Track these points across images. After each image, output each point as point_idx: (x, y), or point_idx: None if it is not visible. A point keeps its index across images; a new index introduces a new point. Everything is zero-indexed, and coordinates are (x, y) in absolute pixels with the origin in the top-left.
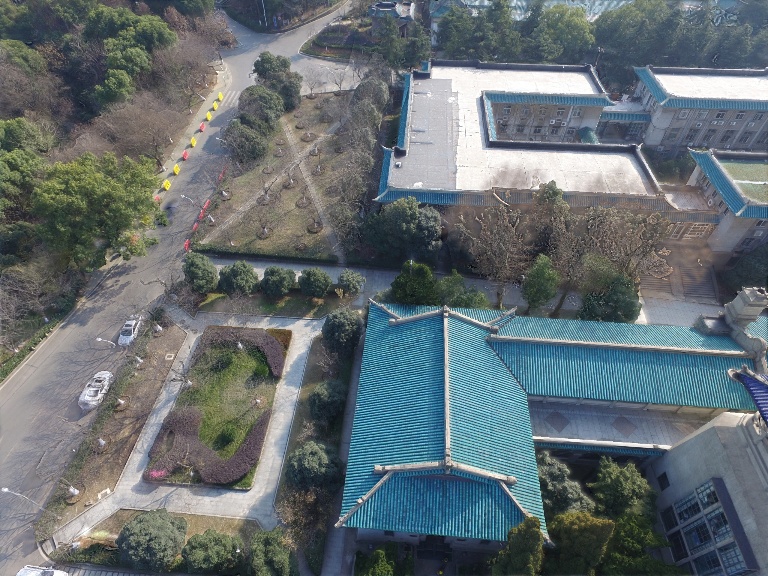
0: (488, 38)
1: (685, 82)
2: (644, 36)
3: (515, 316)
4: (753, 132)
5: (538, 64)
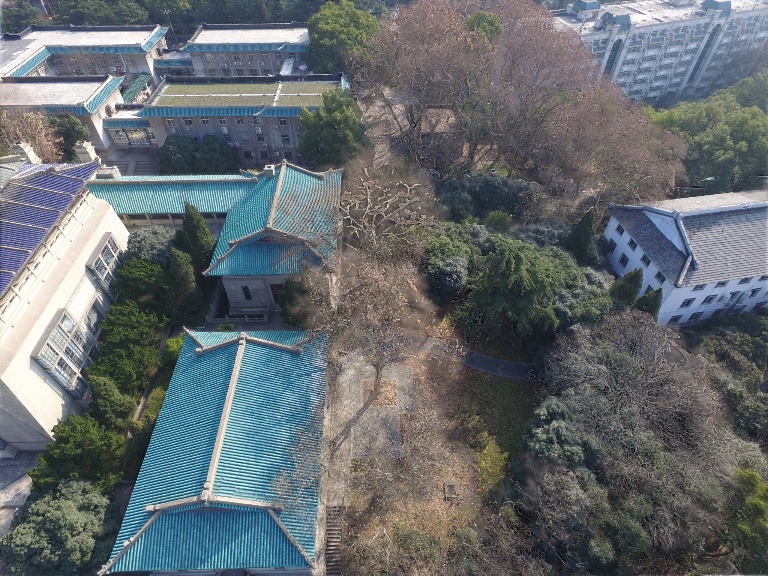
0: (77, 6)
1: (224, 34)
2: (202, 1)
3: None
4: (269, 70)
5: (118, 26)
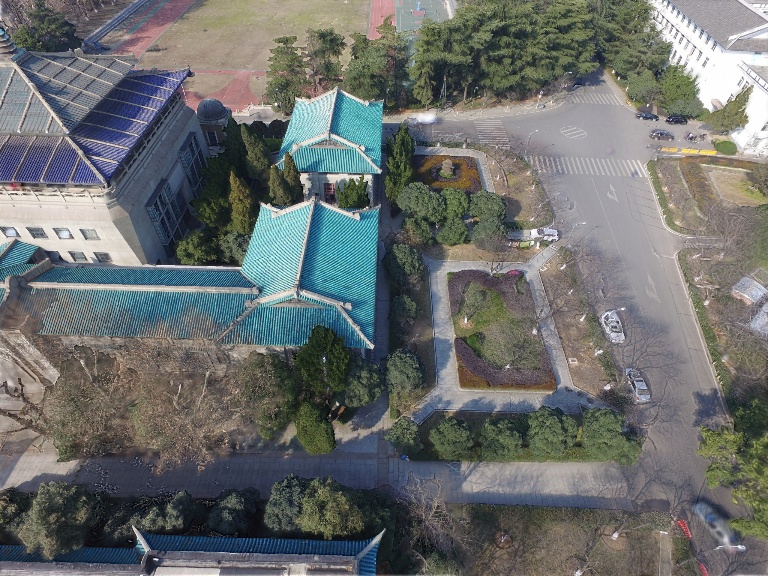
0: None
1: None
2: None
3: None
4: None
5: None
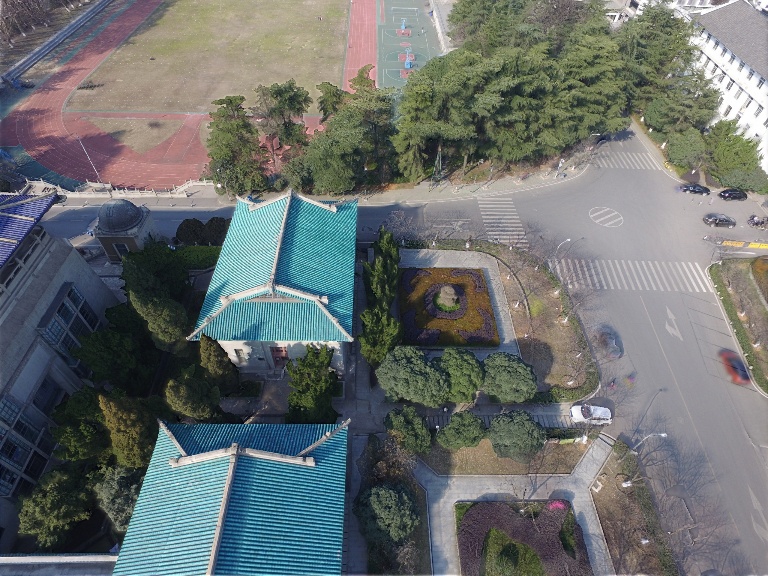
0: None
1: None
2: None
3: None
4: None
5: None
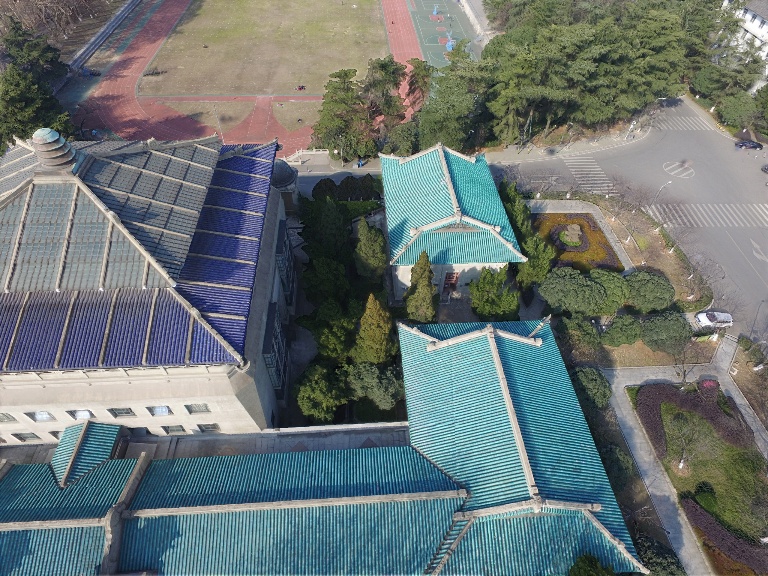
0: None
1: None
2: None
3: (425, 575)
4: None
5: None
